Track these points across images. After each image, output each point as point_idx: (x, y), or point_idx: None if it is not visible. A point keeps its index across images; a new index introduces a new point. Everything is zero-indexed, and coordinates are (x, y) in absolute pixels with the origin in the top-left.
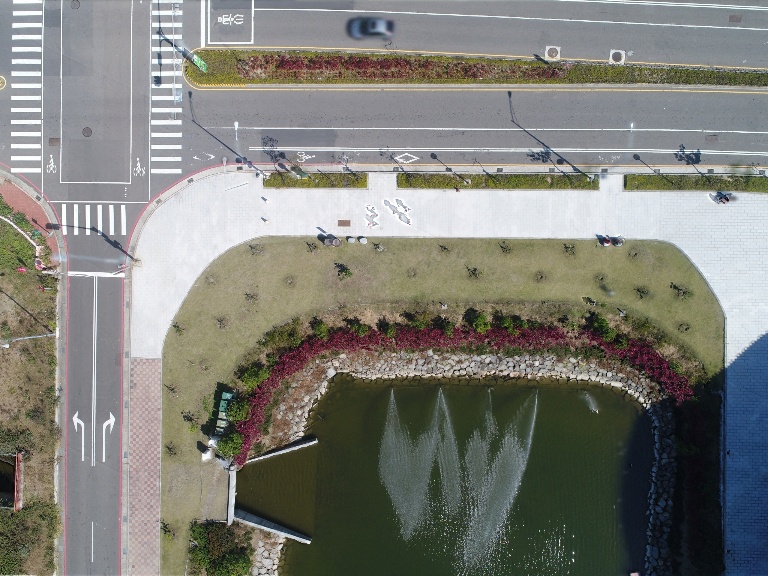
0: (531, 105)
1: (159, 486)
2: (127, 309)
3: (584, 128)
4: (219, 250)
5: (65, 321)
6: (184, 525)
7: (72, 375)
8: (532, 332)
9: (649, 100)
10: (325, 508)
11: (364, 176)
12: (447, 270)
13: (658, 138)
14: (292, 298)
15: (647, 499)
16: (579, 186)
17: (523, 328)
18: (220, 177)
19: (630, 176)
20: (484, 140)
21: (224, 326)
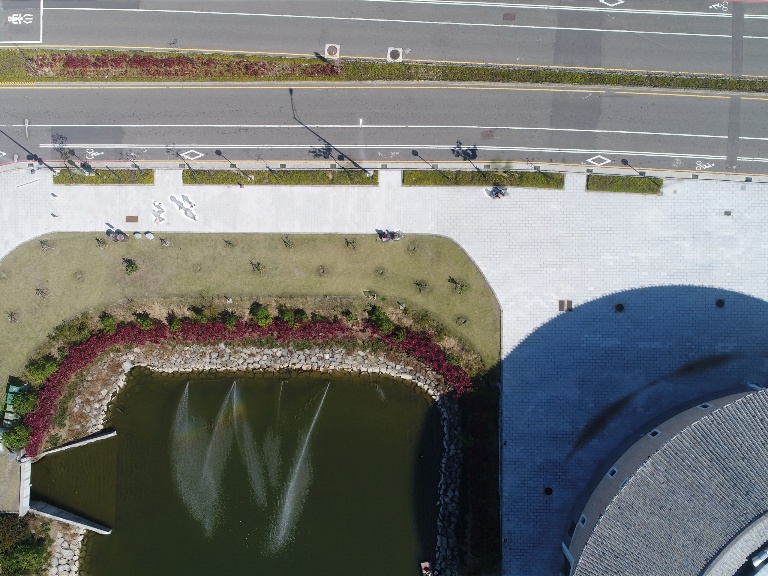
0: (312, 102)
1: None
2: None
3: (364, 125)
4: (11, 246)
5: None
6: None
7: None
8: (314, 325)
9: (426, 97)
10: (126, 500)
11: (150, 172)
12: (232, 265)
13: (435, 134)
14: (81, 293)
15: (437, 490)
16: (358, 182)
17: (303, 321)
18: (11, 174)
19: (408, 172)
20: (267, 137)
21: (14, 320)
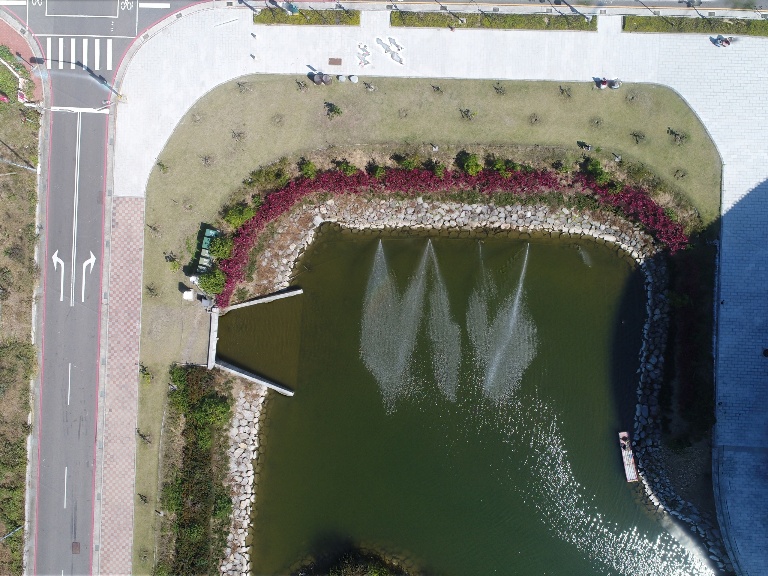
0: None
1: (139, 328)
2: (111, 146)
3: None
4: (206, 87)
5: (47, 157)
6: (163, 368)
7: (53, 213)
8: (524, 176)
9: None
10: (309, 362)
11: (357, 13)
12: (439, 111)
13: None
14: (280, 137)
15: (638, 357)
16: (576, 26)
17: (515, 170)
18: (209, 12)
19: (629, 17)
20: None
21: (209, 164)
